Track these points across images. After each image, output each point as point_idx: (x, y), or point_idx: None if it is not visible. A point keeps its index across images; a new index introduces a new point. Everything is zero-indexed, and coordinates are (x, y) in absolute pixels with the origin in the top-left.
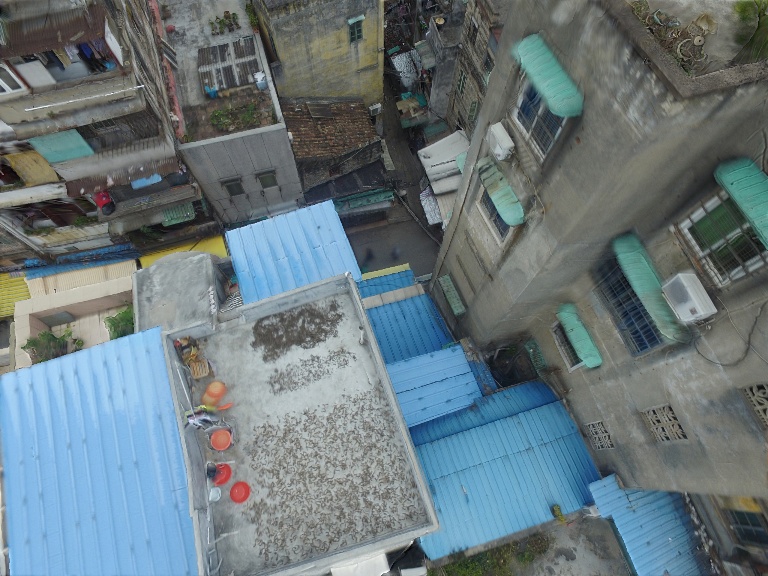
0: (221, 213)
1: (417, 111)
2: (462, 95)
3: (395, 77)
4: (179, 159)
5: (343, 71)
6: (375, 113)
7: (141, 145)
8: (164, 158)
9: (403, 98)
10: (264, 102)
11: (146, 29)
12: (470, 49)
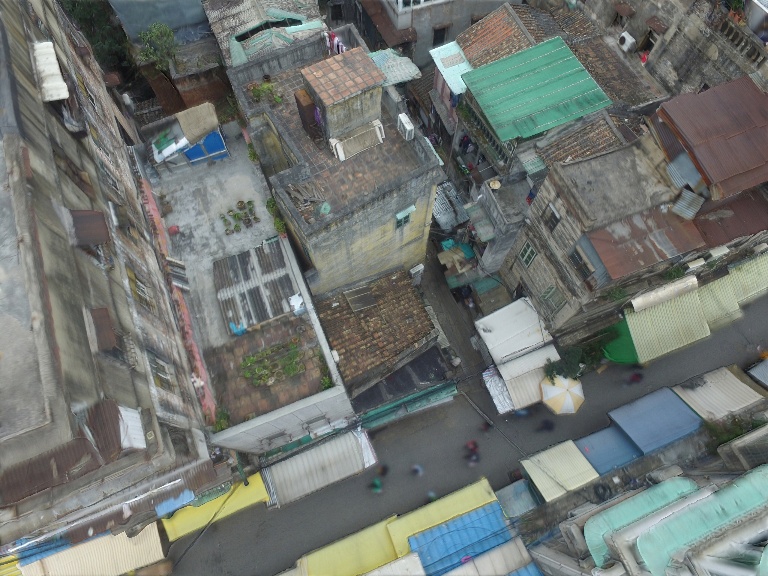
0: (257, 451)
1: (464, 265)
2: (527, 265)
3: (433, 225)
4: (212, 449)
5: (385, 252)
6: (416, 274)
7: (167, 472)
8: (195, 466)
9: (445, 248)
10: (305, 333)
11: (150, 265)
12: (544, 231)
